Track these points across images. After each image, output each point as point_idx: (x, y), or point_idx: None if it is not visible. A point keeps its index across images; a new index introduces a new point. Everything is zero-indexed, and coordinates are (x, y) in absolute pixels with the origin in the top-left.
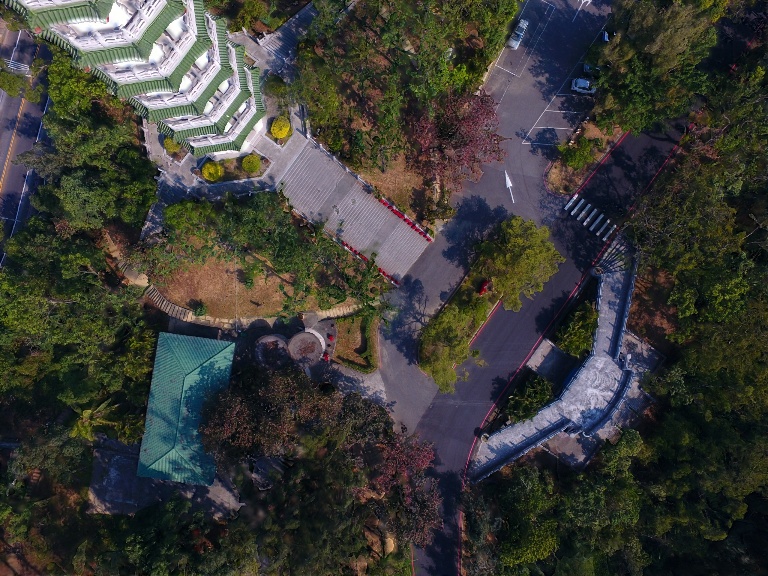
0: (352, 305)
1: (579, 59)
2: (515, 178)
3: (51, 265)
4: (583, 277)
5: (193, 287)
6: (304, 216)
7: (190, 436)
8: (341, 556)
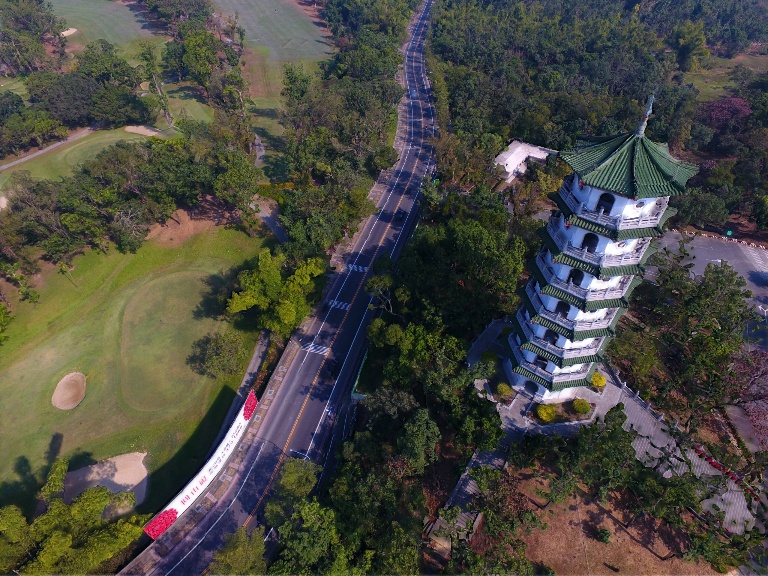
0: None
1: None
2: None
3: (378, 510)
4: None
5: (530, 545)
6: (639, 460)
7: None
8: None
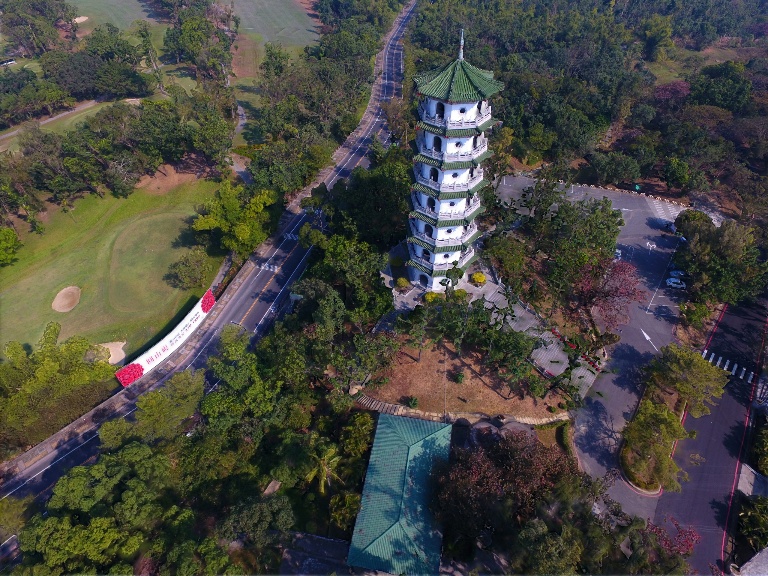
0: (543, 418)
1: (664, 271)
2: (651, 334)
3: None
4: (748, 410)
5: (405, 386)
6: None
7: (414, 511)
8: (666, 571)
